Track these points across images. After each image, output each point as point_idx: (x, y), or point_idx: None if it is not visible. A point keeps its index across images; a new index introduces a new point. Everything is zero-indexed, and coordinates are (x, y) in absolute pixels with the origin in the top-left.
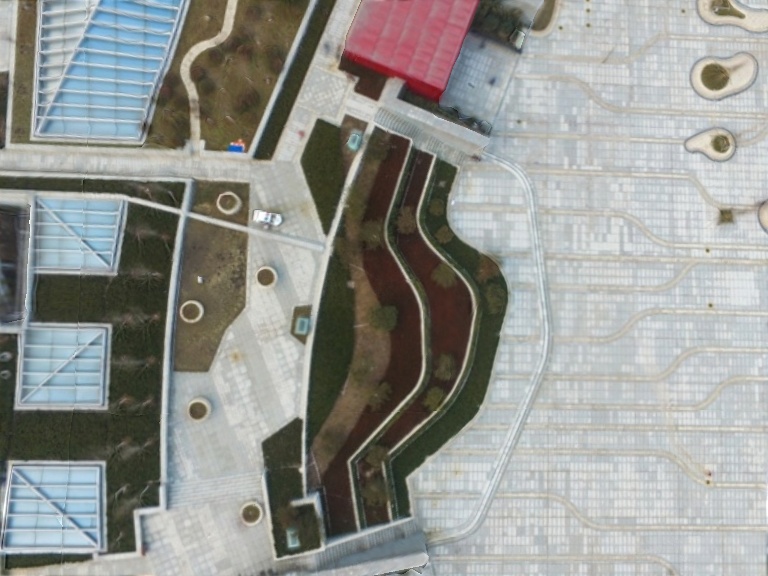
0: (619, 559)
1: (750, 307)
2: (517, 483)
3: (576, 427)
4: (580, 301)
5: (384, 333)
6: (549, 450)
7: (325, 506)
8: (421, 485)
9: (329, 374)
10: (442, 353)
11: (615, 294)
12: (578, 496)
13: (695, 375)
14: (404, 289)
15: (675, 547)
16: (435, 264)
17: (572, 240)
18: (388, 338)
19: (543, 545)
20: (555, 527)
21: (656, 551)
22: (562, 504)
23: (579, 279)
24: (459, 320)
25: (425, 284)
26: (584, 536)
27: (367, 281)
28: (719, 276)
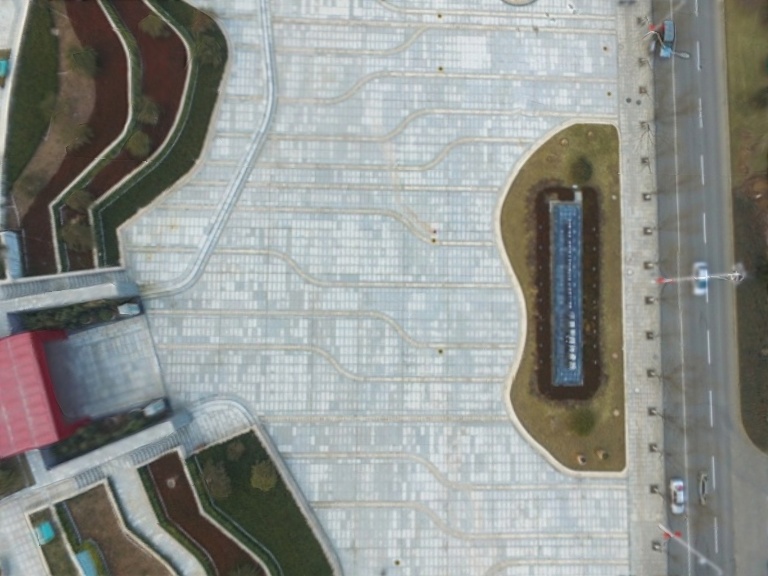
0: (341, 315)
1: (481, 70)
2: (237, 239)
3: (299, 186)
4: (307, 64)
5: (88, 80)
6: (270, 208)
7: (22, 247)
8: (135, 238)
9: (29, 118)
10: (148, 100)
11: (343, 57)
12: (299, 253)
13: (423, 136)
14: (110, 37)
15: (399, 304)
16: (146, 16)
17: (300, 4)
18: (93, 85)
19: (262, 300)
20: (275, 283)
21: (379, 307)
22: (283, 260)
23: (306, 42)
24: (172, 73)
25: (136, 36)
26: (305, 292)
27: (71, 28)
28: (450, 40)
